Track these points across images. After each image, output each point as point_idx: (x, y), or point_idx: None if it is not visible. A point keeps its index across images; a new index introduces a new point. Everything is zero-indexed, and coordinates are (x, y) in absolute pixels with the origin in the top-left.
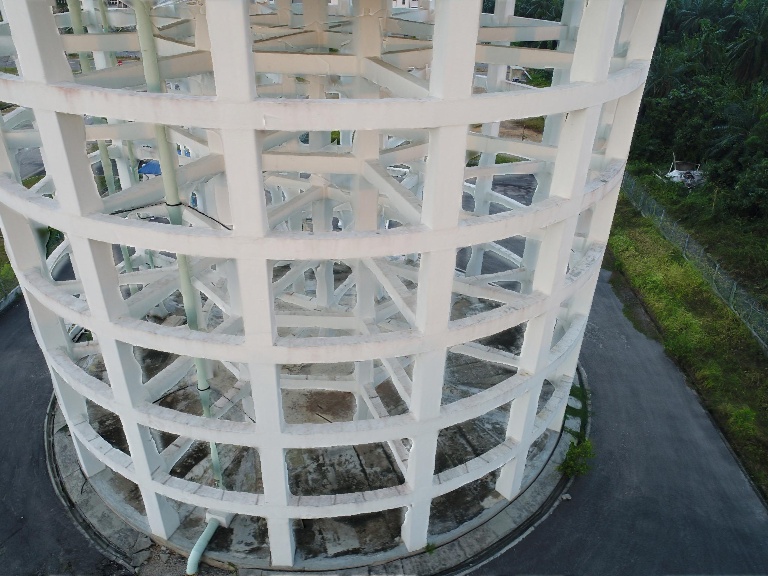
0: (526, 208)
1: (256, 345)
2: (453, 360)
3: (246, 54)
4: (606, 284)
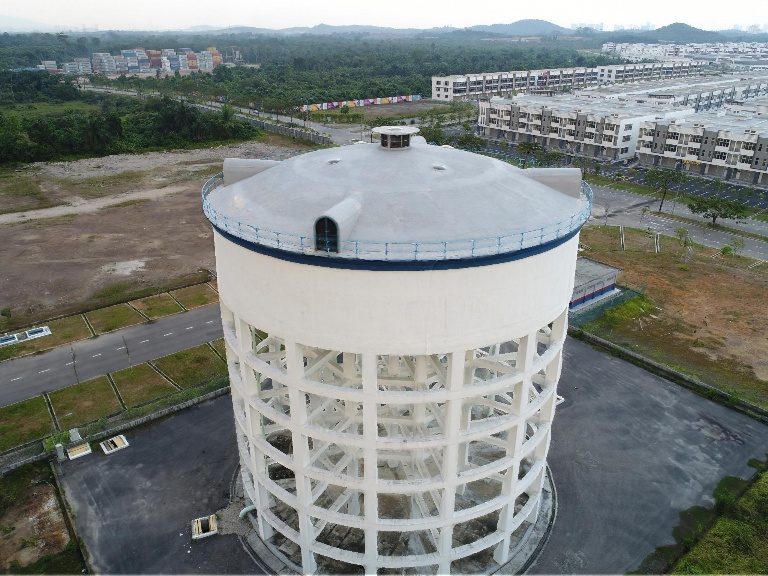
0: (340, 433)
1: (249, 433)
2: None
3: (242, 340)
4: (651, 548)
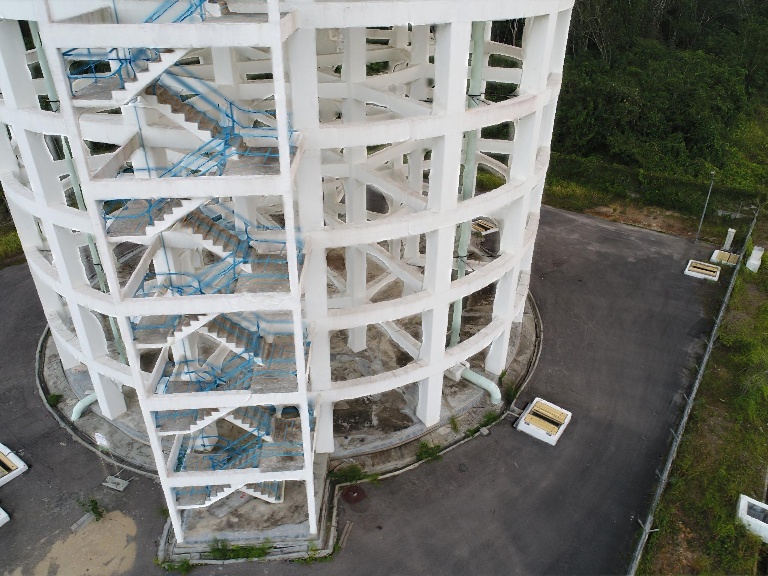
0: None
1: None
2: None
3: None
4: None
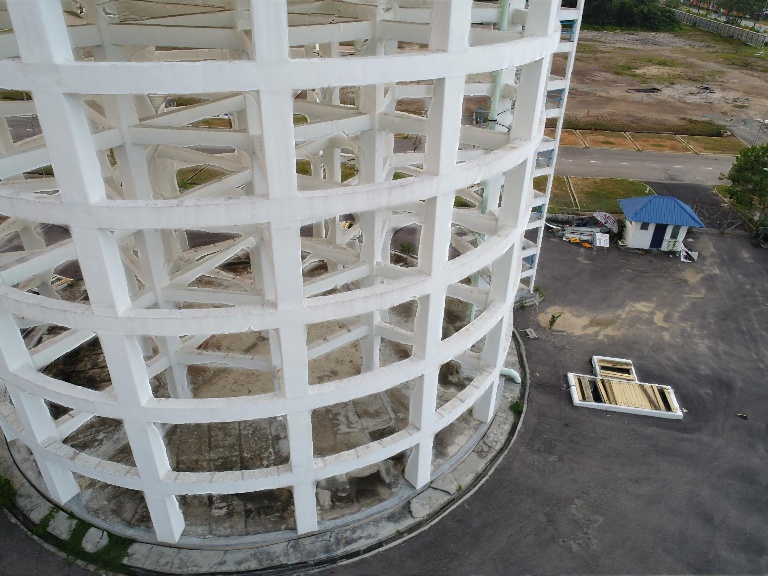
0: None
1: None
2: (221, 425)
3: None
4: None
